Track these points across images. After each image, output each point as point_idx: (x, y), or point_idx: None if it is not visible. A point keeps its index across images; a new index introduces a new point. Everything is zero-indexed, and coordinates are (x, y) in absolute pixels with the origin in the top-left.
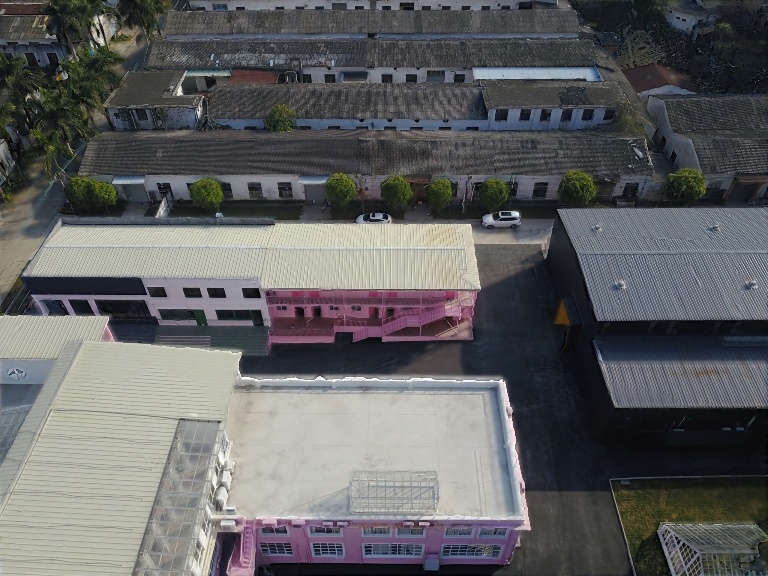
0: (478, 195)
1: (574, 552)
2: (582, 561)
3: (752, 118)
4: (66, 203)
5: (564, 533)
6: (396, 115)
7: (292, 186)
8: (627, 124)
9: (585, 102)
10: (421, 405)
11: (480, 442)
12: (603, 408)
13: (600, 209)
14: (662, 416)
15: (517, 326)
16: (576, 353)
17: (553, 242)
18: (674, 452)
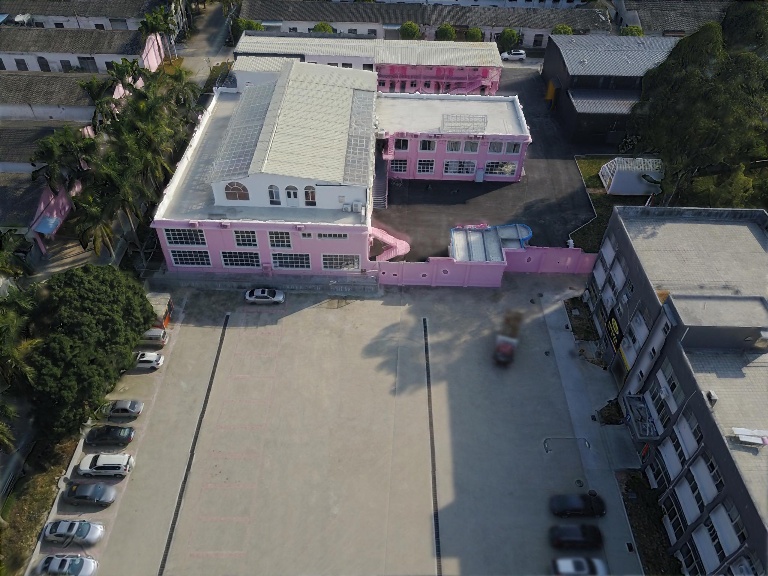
0: (498, 43)
1: (554, 178)
2: (558, 181)
3: (679, 4)
4: (226, 41)
5: (549, 172)
6: None
7: (377, 33)
8: None
9: None
10: (473, 105)
11: (506, 117)
12: (572, 120)
13: (575, 35)
14: (604, 120)
15: (523, 100)
16: (558, 108)
17: (546, 58)
18: (611, 146)
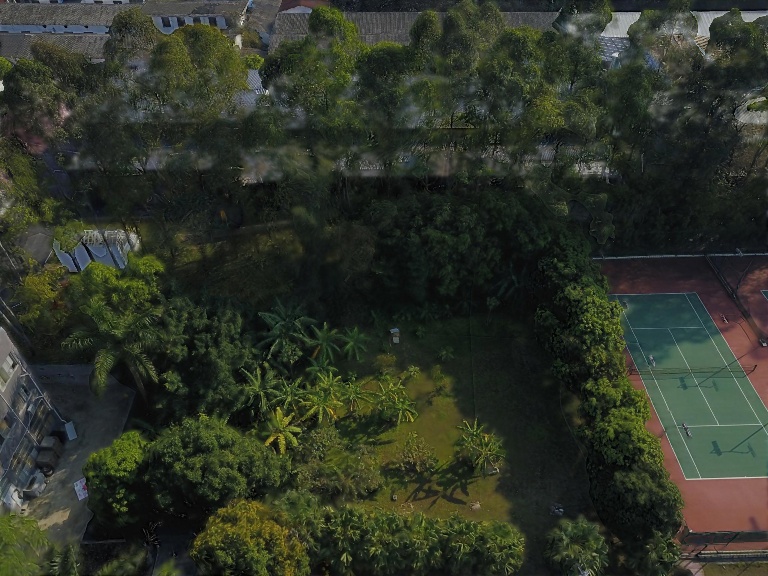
0: None
1: None
2: None
3: None
4: None
5: None
6: (70, 22)
7: None
8: (236, 28)
9: (209, 12)
10: None
11: None
12: None
13: None
14: None
15: None
16: None
17: None
18: None
